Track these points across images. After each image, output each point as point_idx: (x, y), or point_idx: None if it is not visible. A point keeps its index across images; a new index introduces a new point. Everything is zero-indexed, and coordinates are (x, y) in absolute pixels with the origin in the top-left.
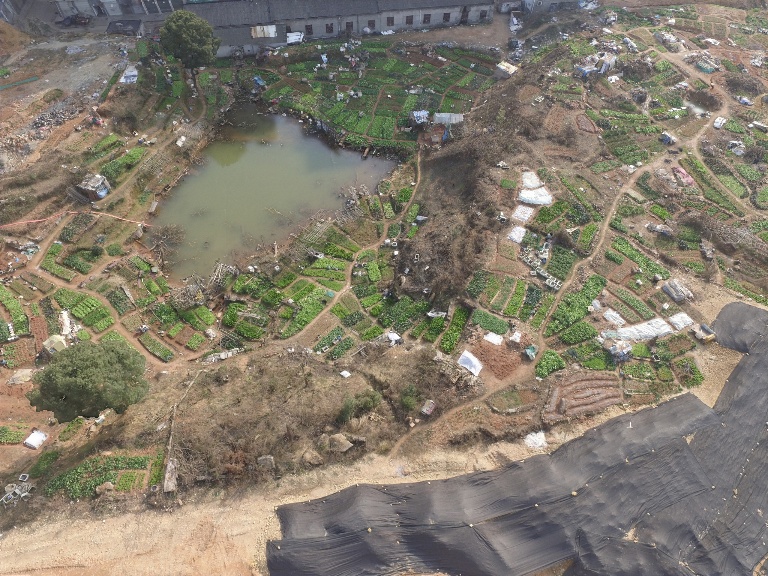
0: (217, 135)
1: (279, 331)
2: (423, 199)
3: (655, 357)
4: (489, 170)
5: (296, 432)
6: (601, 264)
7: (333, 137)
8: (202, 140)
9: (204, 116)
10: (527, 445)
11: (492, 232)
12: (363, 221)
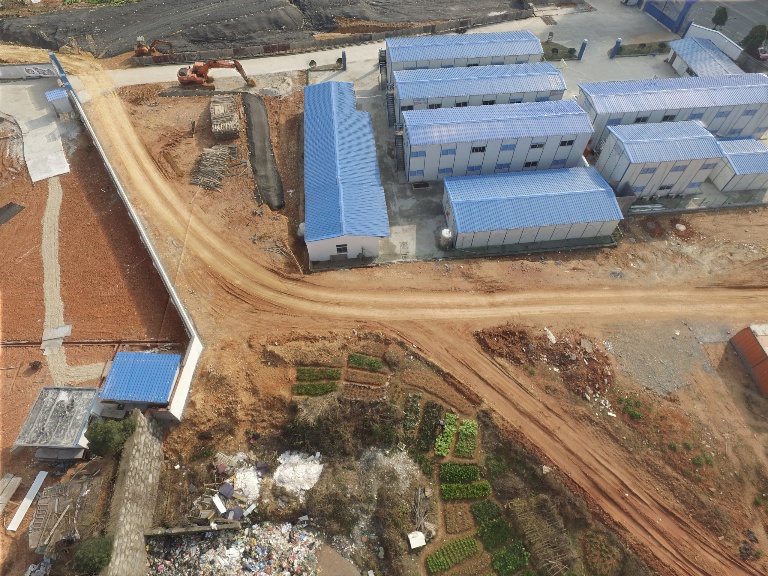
0: None
1: None
2: None
3: (123, 0)
4: None
5: None
6: None
7: None
8: None
9: None
10: None
11: None
12: None
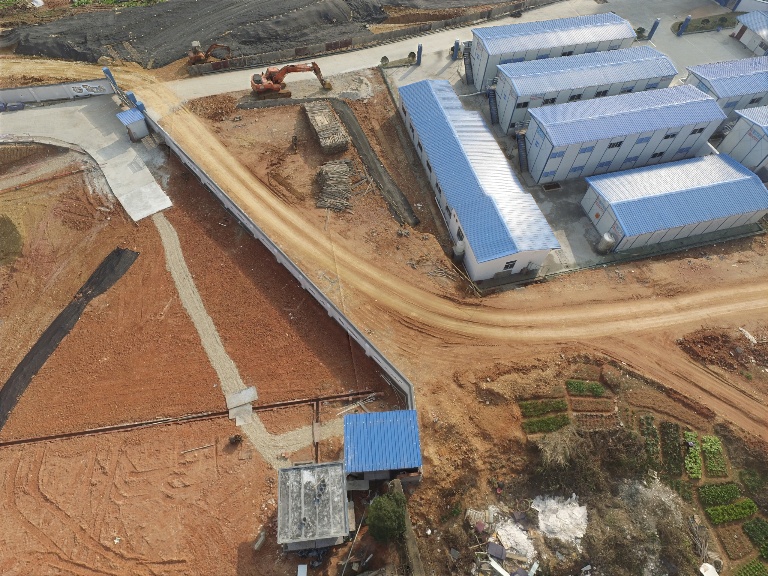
0: None
1: None
2: None
3: None
4: None
5: None
6: None
7: None
8: None
9: None
10: None
11: None
12: None
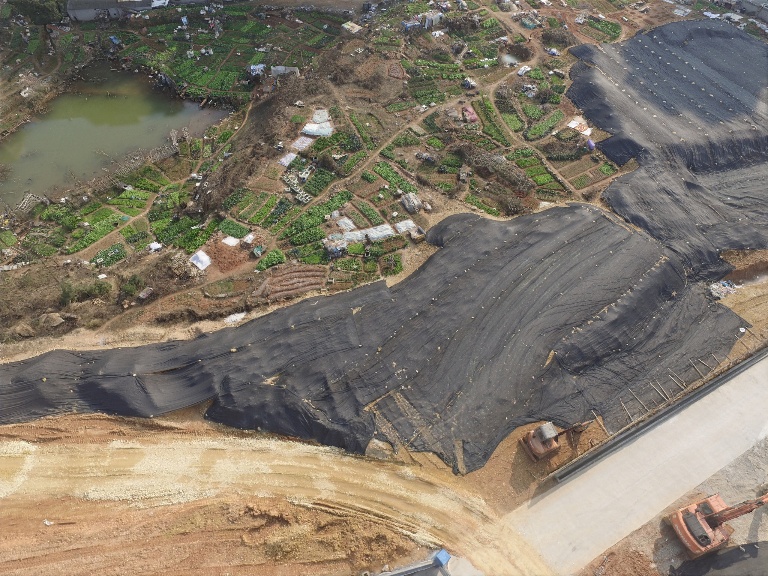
0: (66, 88)
1: (65, 248)
2: (237, 139)
3: (366, 253)
4: (285, 108)
5: (18, 312)
6: (354, 183)
7: (174, 89)
8: (50, 92)
9: (56, 71)
10: (225, 322)
11: (267, 158)
12: (181, 160)
